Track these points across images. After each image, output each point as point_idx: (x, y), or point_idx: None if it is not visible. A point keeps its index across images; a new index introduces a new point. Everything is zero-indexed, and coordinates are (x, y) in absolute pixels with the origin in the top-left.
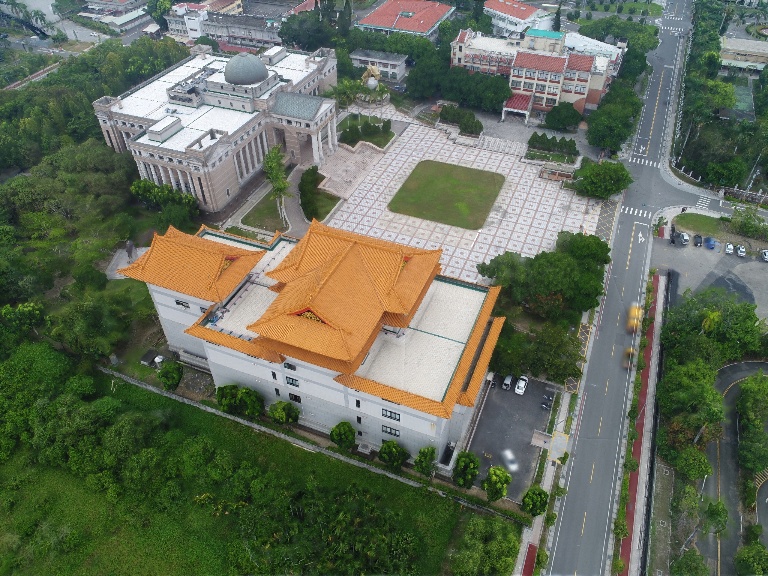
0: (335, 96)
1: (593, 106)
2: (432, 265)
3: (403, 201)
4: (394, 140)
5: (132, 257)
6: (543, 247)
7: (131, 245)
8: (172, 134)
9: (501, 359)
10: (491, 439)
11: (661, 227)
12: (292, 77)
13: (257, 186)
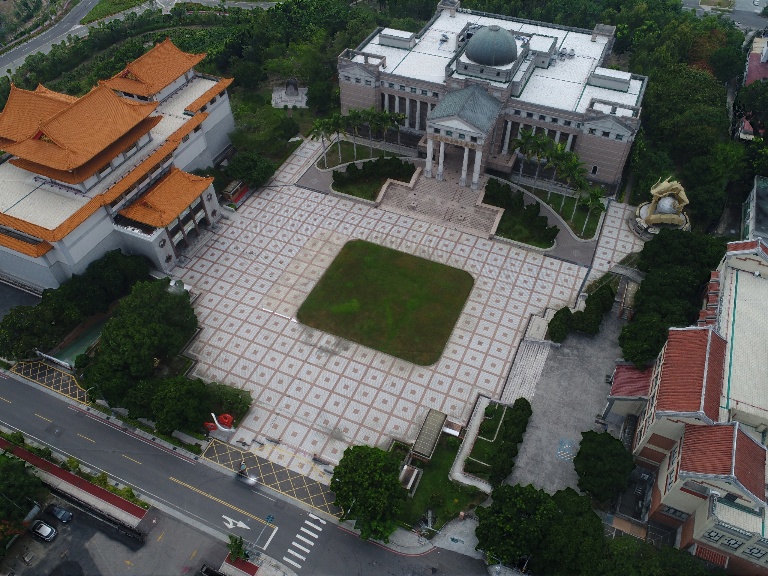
0: (522, 142)
1: (679, 543)
2: (57, 166)
3: (367, 252)
4: (530, 249)
5: (288, 91)
6: (245, 383)
7: (290, 82)
8: (394, 46)
9: (46, 289)
10: (0, 296)
11: (254, 569)
12: (552, 100)
13: (407, 145)
